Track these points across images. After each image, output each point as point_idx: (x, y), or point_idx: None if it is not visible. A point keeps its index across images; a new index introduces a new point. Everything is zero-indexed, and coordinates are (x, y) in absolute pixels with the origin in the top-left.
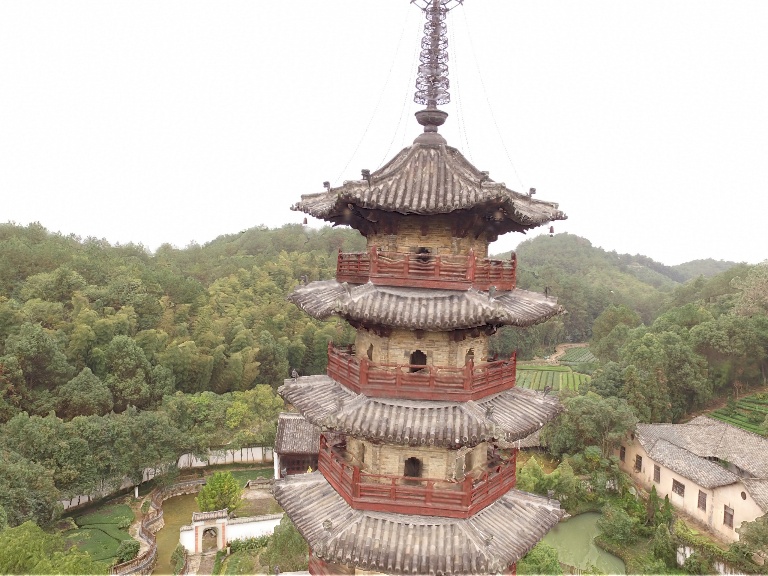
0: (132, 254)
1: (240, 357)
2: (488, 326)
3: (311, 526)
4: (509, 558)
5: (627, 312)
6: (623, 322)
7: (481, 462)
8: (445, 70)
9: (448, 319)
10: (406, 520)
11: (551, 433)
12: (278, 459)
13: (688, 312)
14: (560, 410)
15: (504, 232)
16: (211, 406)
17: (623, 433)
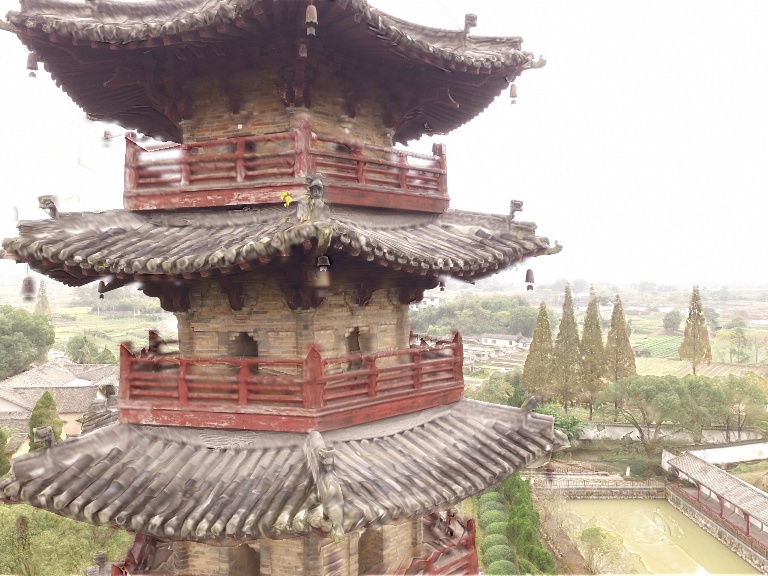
0: None
1: None
2: None
3: None
4: None
5: None
6: None
7: None
8: None
9: None
10: None
11: None
12: None
13: None
14: None
15: (84, 99)
16: None
17: None
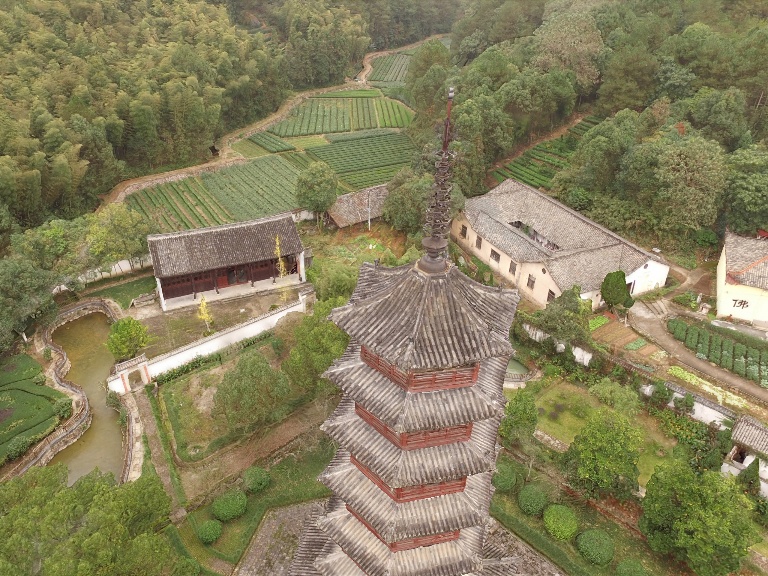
0: None
1: (65, 160)
2: None
3: (367, 511)
4: (487, 505)
5: (441, 50)
6: (437, 62)
7: None
8: None
9: (468, 418)
10: None
11: (394, 211)
12: None
13: (498, 63)
14: None
15: None
16: (67, 236)
17: (455, 214)
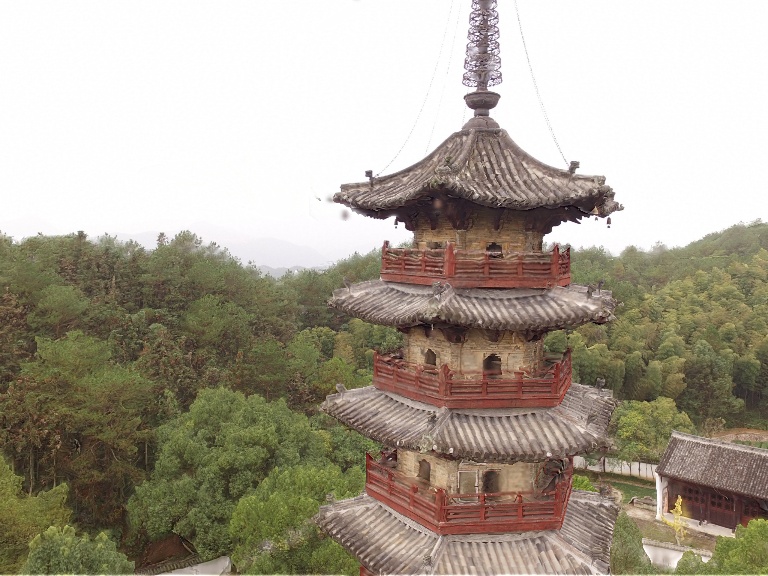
0: (592, 258)
1: (659, 366)
2: (523, 330)
3: None
4: None
5: None
6: None
7: (523, 488)
8: (491, 45)
9: (400, 316)
10: (405, 519)
11: None
12: (662, 481)
13: None
14: (599, 445)
15: None
16: None
17: None
